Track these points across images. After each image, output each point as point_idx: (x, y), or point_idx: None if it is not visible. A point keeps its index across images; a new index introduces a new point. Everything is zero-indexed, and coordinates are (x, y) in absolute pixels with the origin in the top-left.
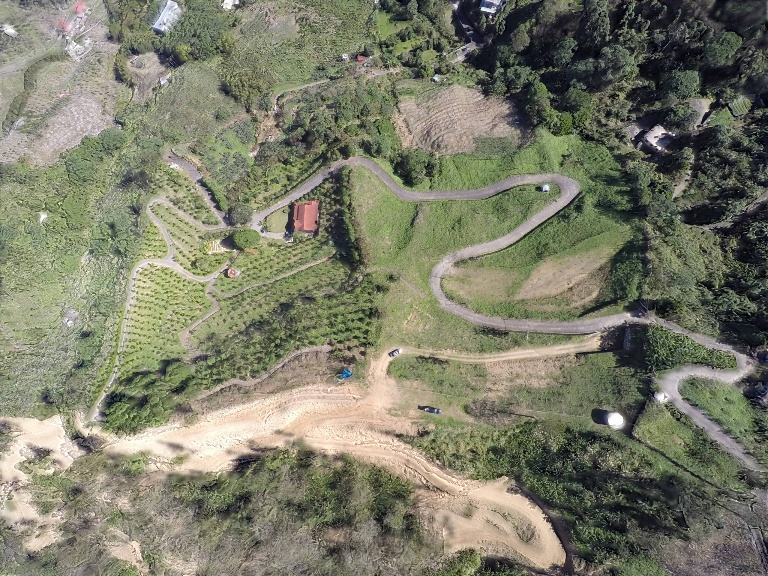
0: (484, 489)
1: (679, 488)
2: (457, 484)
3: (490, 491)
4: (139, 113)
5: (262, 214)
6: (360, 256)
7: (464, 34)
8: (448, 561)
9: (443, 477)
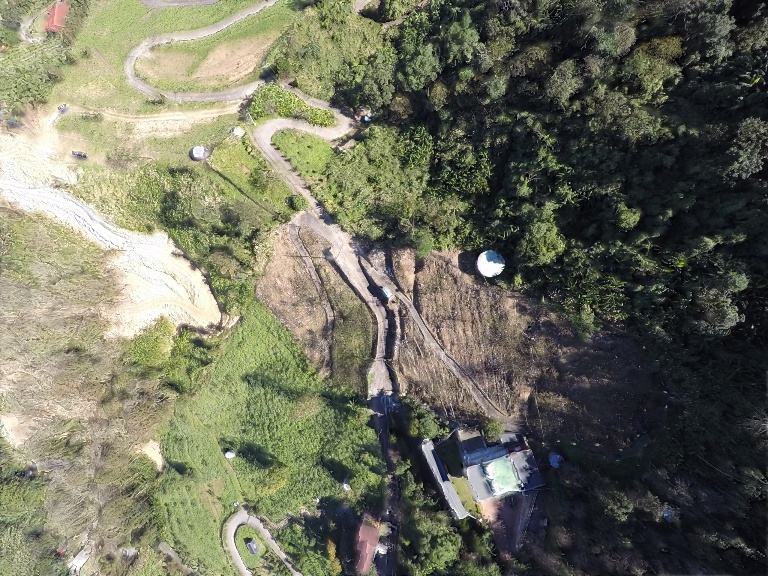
0: (152, 248)
1: None
2: (118, 235)
3: (157, 251)
4: None
5: (34, 17)
6: None
7: None
8: (147, 327)
9: (106, 227)
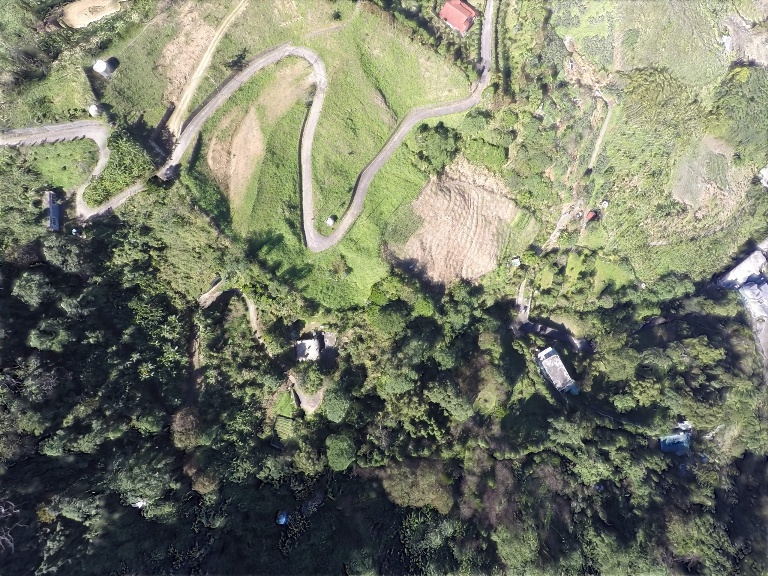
0: None
1: (28, 78)
2: None
3: None
4: (713, 2)
5: None
6: (375, 3)
7: (542, 322)
8: None
9: None
